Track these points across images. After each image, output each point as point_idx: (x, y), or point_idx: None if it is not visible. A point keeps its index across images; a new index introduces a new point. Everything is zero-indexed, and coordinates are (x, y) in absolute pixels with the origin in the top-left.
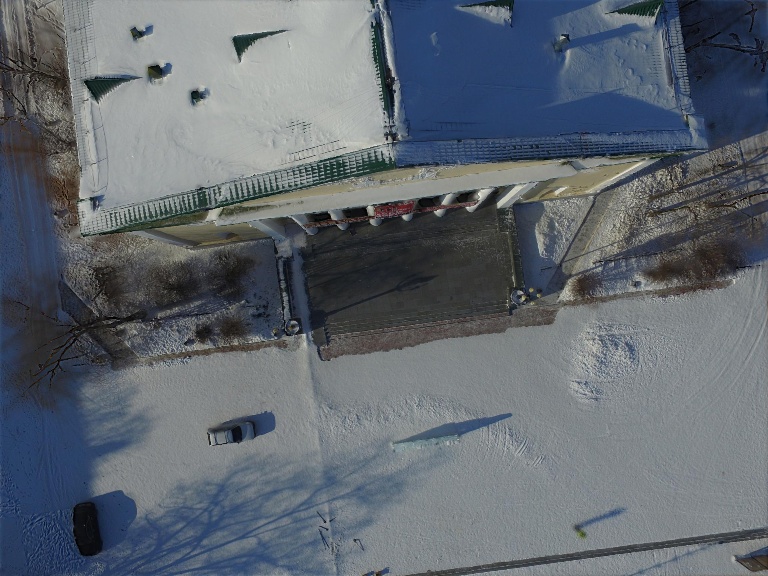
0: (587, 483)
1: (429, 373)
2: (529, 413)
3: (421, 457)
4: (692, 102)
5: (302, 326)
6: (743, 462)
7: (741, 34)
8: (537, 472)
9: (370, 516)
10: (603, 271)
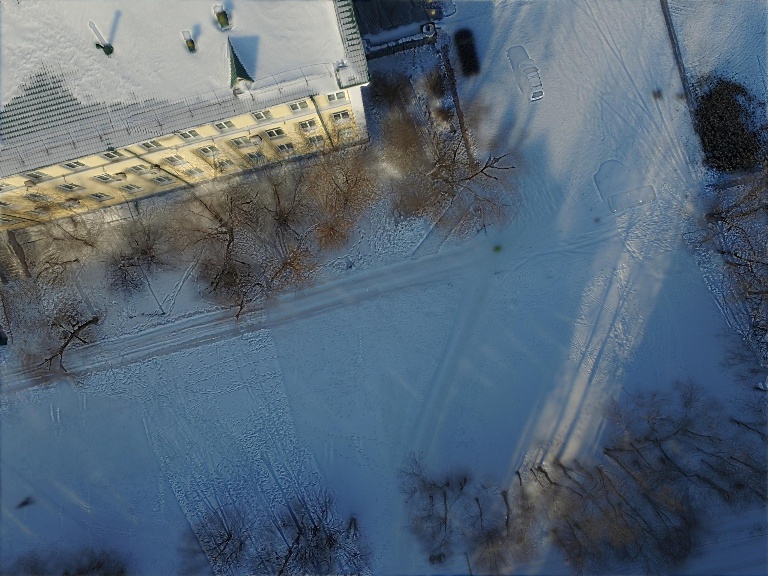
0: None
1: None
2: None
3: None
4: None
5: None
6: None
7: None
8: None
9: None
10: None
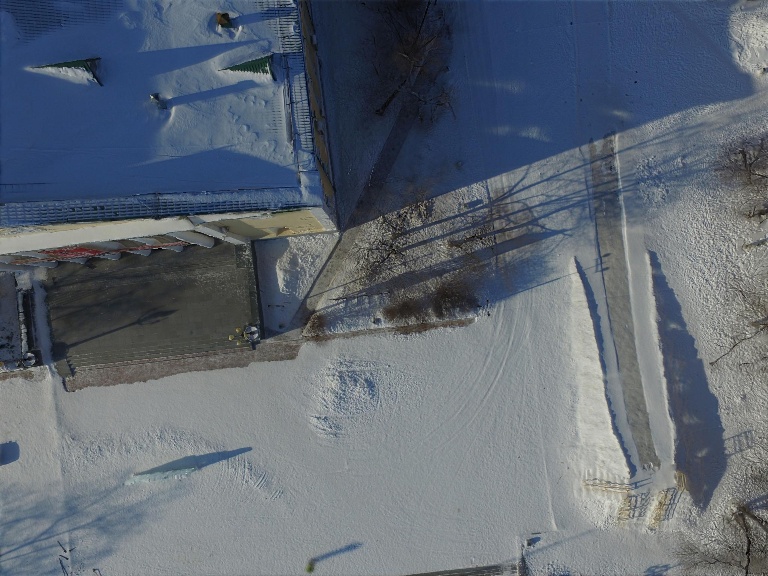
0: (324, 517)
1: (172, 406)
2: (269, 447)
3: (161, 489)
4: (315, 158)
5: (42, 358)
6: (478, 499)
7: (492, 73)
8: (275, 506)
9: (110, 546)
10: (346, 307)
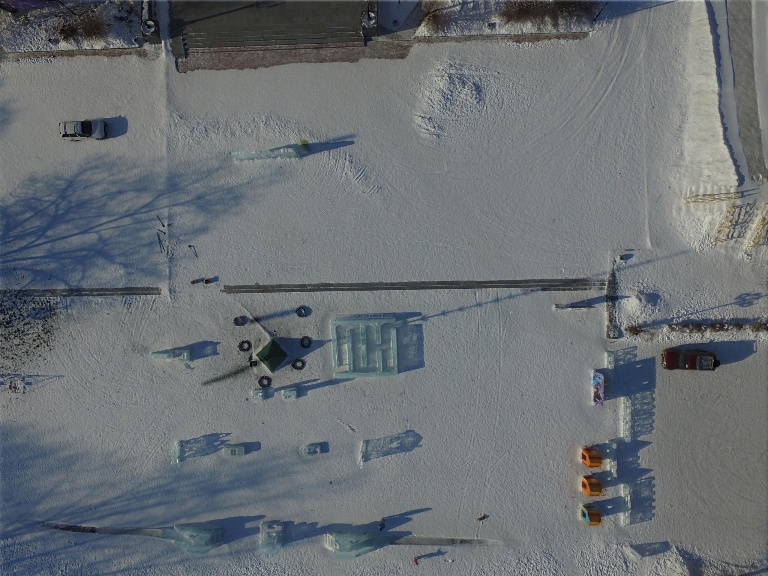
0: (419, 216)
1: (279, 94)
2: (371, 143)
3: (262, 174)
4: None
5: (160, 31)
6: (575, 212)
7: None
8: (372, 200)
9: (207, 225)
10: (461, 11)
